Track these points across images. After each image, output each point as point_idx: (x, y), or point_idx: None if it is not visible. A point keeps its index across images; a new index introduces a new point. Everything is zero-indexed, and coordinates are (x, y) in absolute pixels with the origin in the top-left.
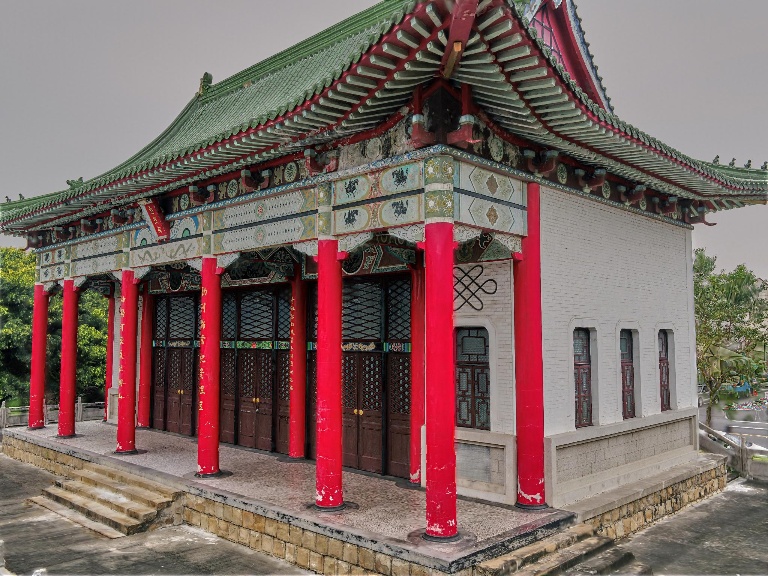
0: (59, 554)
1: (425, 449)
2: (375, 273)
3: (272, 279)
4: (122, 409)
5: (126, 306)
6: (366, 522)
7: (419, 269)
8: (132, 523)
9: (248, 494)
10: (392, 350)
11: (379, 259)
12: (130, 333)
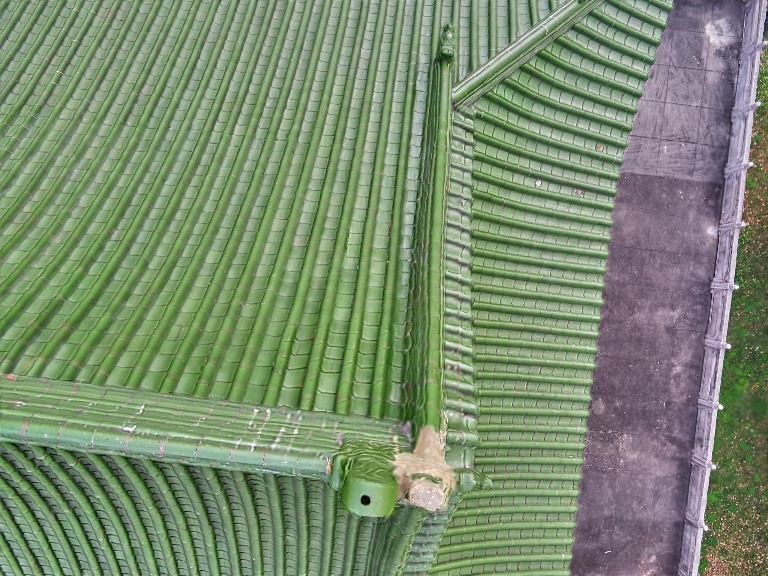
0: None
1: None
2: None
3: None
4: None
5: None
6: None
7: None
8: None
9: None
10: None
11: None
12: None
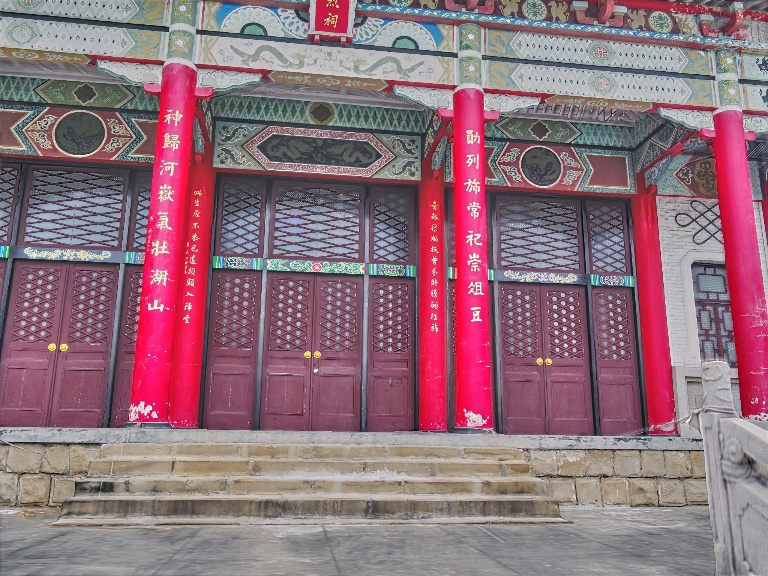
0: None
1: (684, 393)
2: (581, 191)
3: (378, 172)
4: (163, 332)
5: (183, 130)
6: None
7: (651, 195)
8: None
9: None
10: (605, 283)
11: (589, 176)
12: (184, 184)
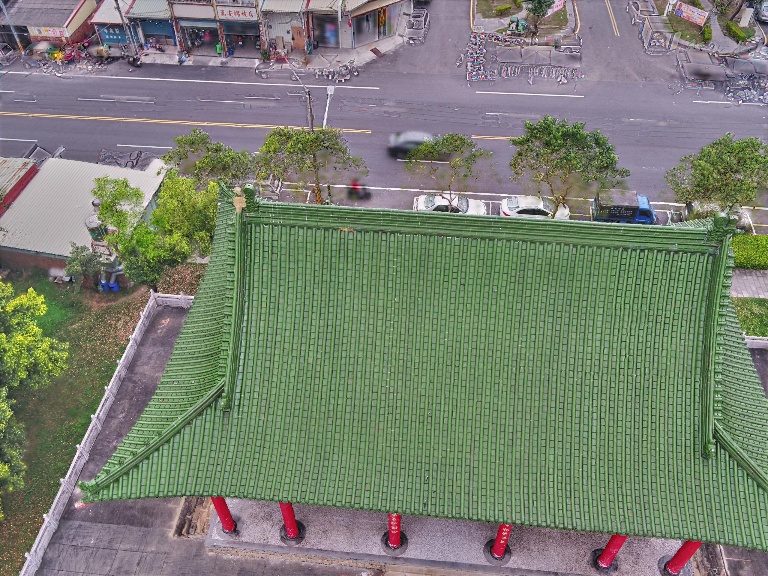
0: None
1: None
2: None
3: None
4: None
5: None
6: (635, 572)
7: None
8: None
9: (554, 569)
10: None
11: None
12: None
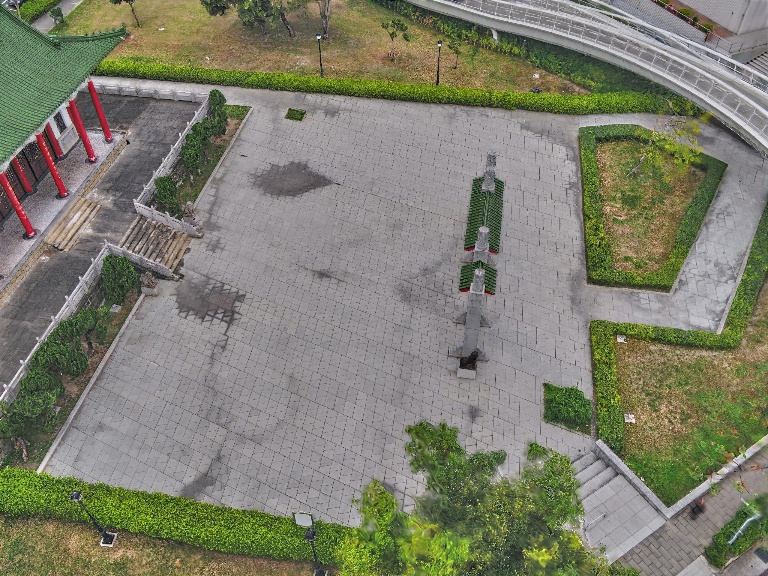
0: (117, 205)
1: None
2: None
3: None
4: None
5: None
6: None
7: None
8: (94, 203)
9: None
10: None
11: None
12: None
